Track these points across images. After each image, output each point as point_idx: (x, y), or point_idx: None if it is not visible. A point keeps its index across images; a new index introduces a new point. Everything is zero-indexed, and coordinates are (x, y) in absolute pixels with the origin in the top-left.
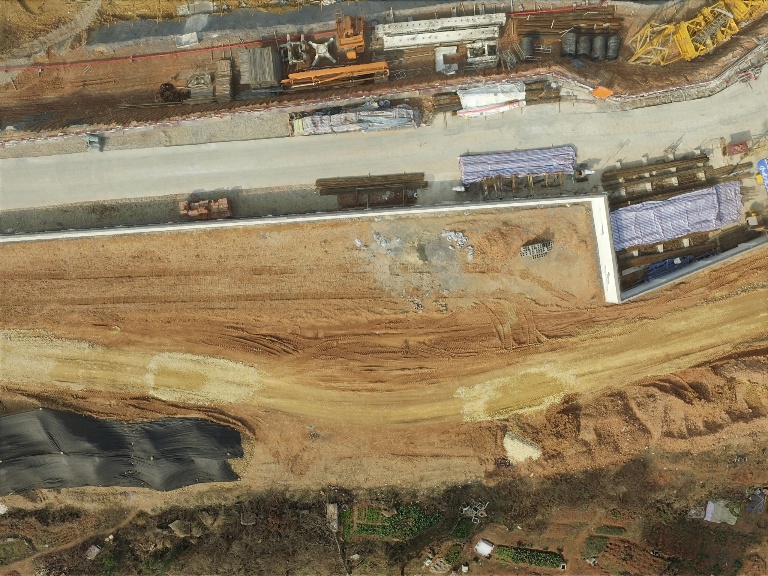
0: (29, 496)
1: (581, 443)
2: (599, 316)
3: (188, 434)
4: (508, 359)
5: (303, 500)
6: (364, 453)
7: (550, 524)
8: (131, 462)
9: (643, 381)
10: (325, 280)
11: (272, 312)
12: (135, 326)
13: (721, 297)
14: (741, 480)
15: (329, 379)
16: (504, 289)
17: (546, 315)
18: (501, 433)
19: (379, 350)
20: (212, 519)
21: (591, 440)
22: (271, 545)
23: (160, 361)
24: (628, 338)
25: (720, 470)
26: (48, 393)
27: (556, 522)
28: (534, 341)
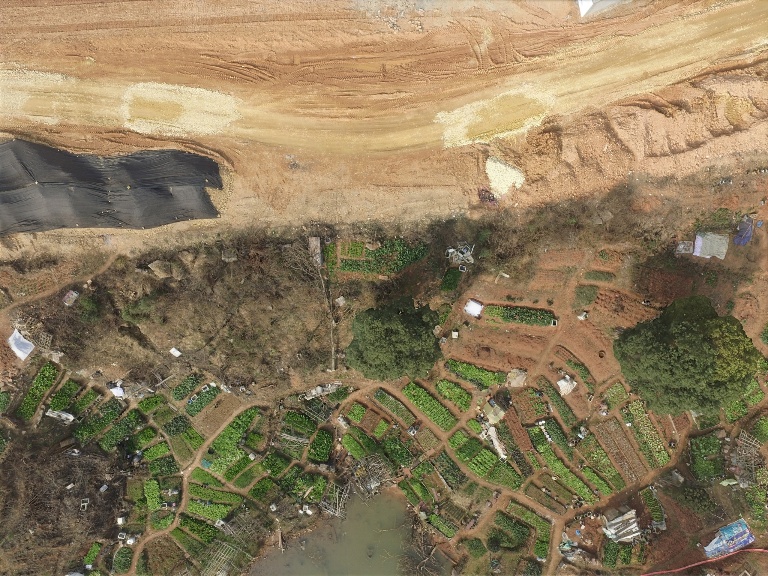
0: (4, 242)
1: (564, 164)
2: (575, 34)
3: (165, 164)
4: (486, 80)
5: (285, 236)
6: (345, 184)
7: (538, 270)
8: (108, 200)
9: (623, 101)
10: (299, 1)
11: (247, 34)
12: (109, 56)
13: (696, 13)
14: (727, 204)
15: (307, 106)
16: (479, 7)
17: (522, 34)
18: (483, 155)
19: (356, 75)
20: (192, 256)
21: (574, 162)
22: (254, 286)
23: (135, 92)
24: (605, 56)
25: (706, 195)
26: (22, 128)
27: (544, 268)
28: (512, 61)
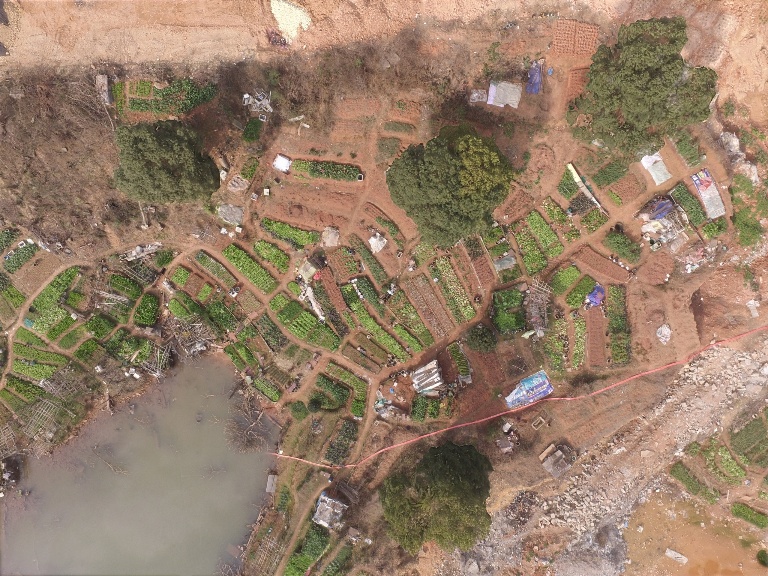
0: None
1: (347, 3)
2: None
3: None
4: None
5: (74, 74)
6: (132, 23)
7: (338, 121)
8: None
9: None
10: None
11: None
12: None
13: None
14: (515, 49)
15: None
16: None
17: None
18: None
19: None
20: None
21: (358, 2)
22: (45, 125)
23: None
24: None
25: (493, 40)
26: None
27: (343, 118)
28: None
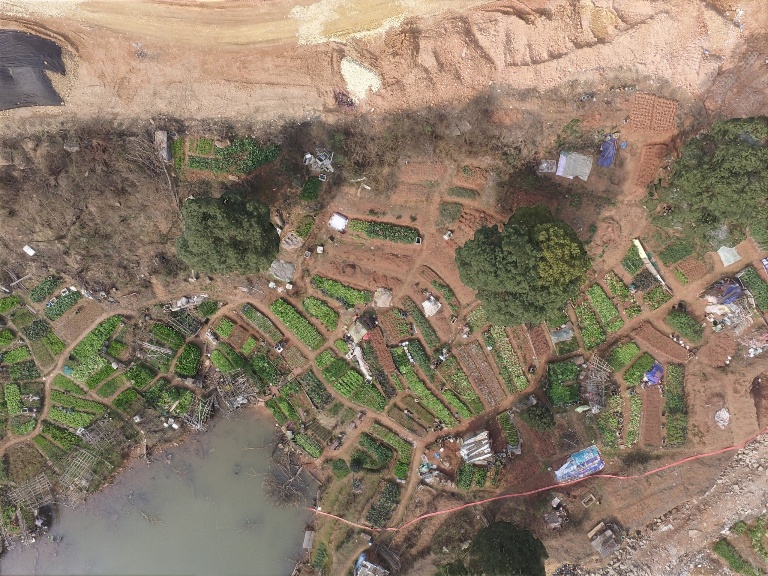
0: None
1: (420, 68)
2: None
3: (4, 44)
4: None
5: (131, 128)
6: (195, 78)
7: (400, 184)
8: None
9: (486, 6)
10: None
11: None
12: None
13: None
14: (589, 122)
15: None
16: None
17: None
18: (336, 54)
19: None
20: (33, 143)
21: (431, 67)
22: (99, 179)
23: None
24: None
25: (568, 111)
26: None
27: (406, 181)
28: None
